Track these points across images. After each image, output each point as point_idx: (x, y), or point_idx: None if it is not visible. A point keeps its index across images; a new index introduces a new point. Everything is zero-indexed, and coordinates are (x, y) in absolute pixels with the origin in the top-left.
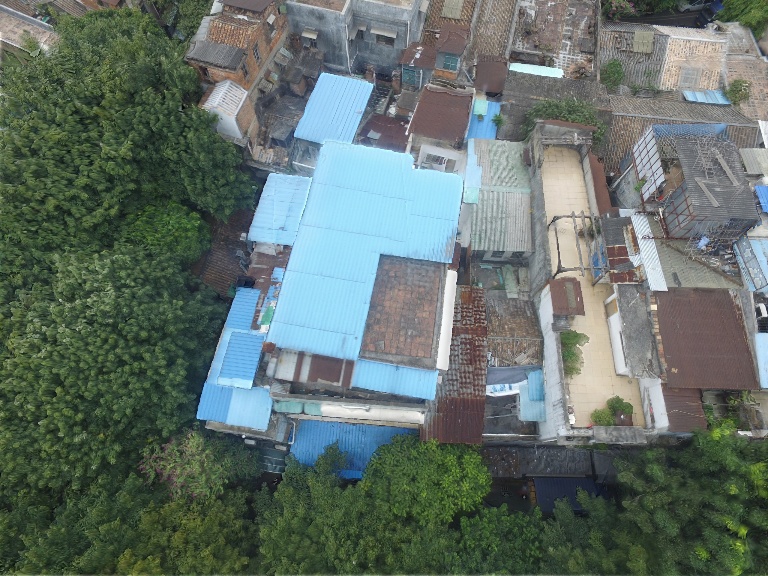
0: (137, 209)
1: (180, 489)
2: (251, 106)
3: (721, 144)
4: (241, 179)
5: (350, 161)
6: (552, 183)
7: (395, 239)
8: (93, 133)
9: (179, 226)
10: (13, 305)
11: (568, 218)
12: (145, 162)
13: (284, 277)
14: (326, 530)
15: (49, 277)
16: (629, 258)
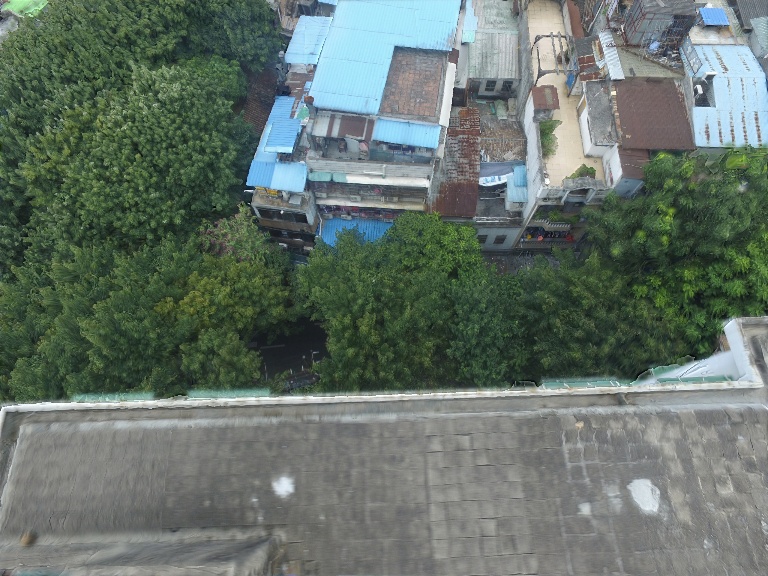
0: (186, 59)
1: None
2: None
3: None
4: (274, 33)
5: None
6: (536, 26)
7: (407, 35)
8: None
9: (222, 69)
10: None
11: (549, 50)
12: (193, 16)
13: (319, 61)
14: (351, 267)
15: (122, 87)
16: (596, 63)
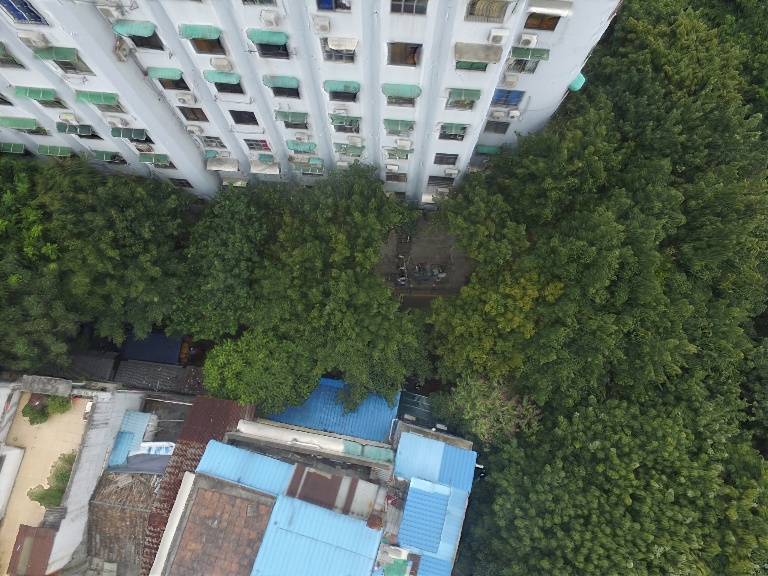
0: None
1: (497, 387)
2: None
3: None
4: None
5: None
6: None
7: None
8: None
9: None
10: None
11: None
12: None
13: None
14: (353, 335)
15: None
16: None
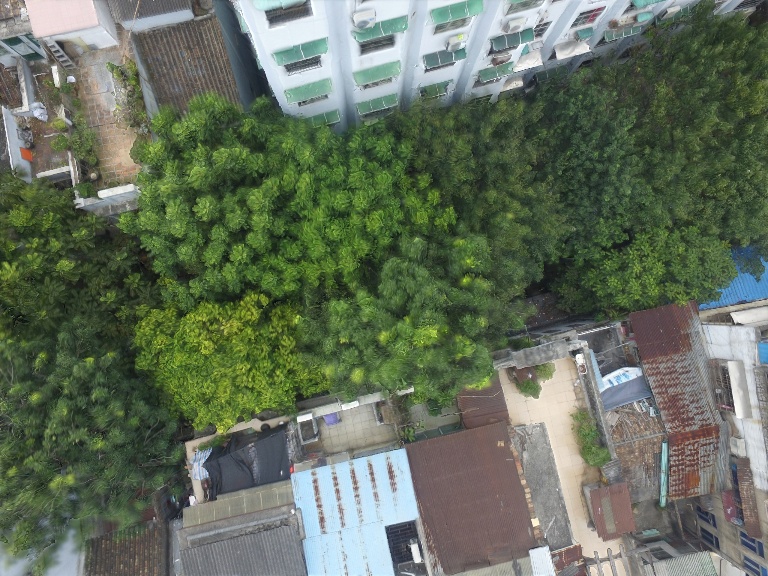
0: None
1: None
2: None
3: None
4: None
5: None
6: None
7: None
8: None
9: None
10: None
11: None
12: None
13: None
14: None
15: None
16: None
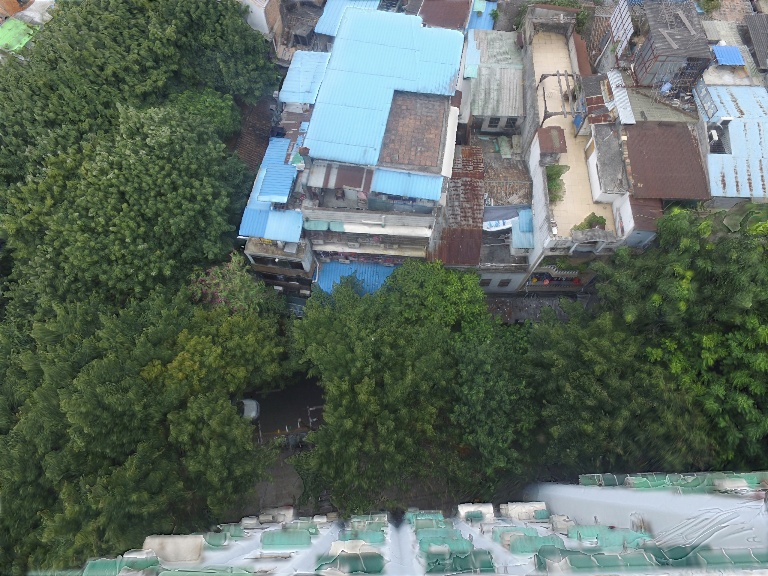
0: (177, 92)
1: None
2: (277, 4)
3: (682, 2)
4: (269, 66)
5: (368, 22)
6: (541, 60)
7: (407, 78)
8: (141, 20)
9: (215, 104)
10: (82, 145)
11: (555, 87)
12: (185, 49)
13: (314, 107)
14: (349, 322)
15: (109, 129)
16: (605, 105)
